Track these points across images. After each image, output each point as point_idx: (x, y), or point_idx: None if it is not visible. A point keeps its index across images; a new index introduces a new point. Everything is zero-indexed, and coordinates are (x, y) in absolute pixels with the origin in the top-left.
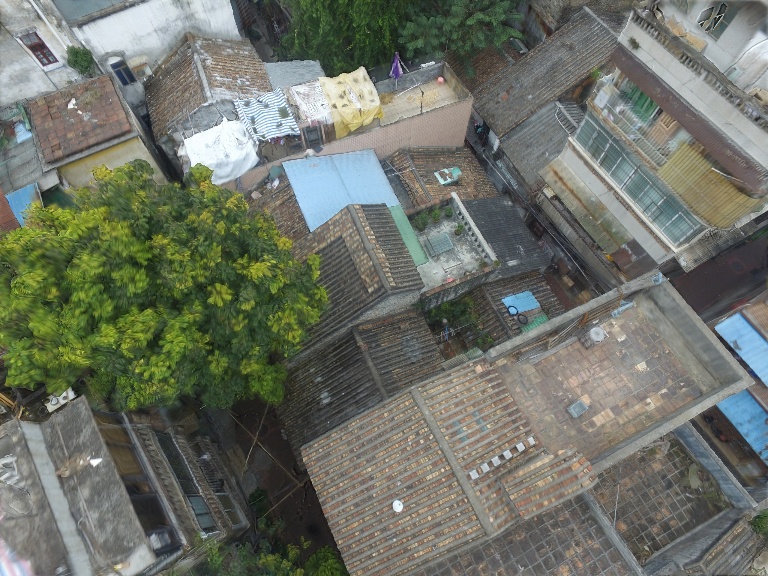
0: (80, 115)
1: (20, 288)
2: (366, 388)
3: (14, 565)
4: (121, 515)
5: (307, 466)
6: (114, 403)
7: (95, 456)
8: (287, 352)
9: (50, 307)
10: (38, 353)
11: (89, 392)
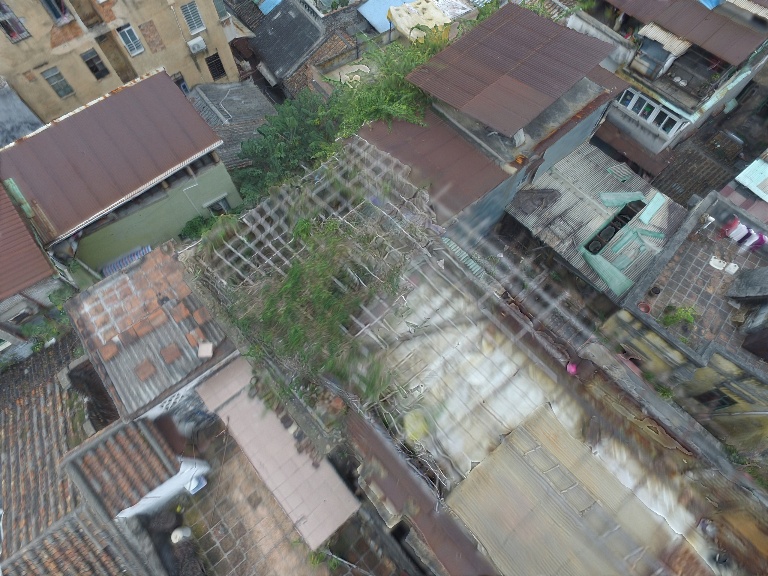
0: None
1: None
2: None
3: None
4: None
5: None
6: None
7: None
8: None
9: None
10: None
11: None
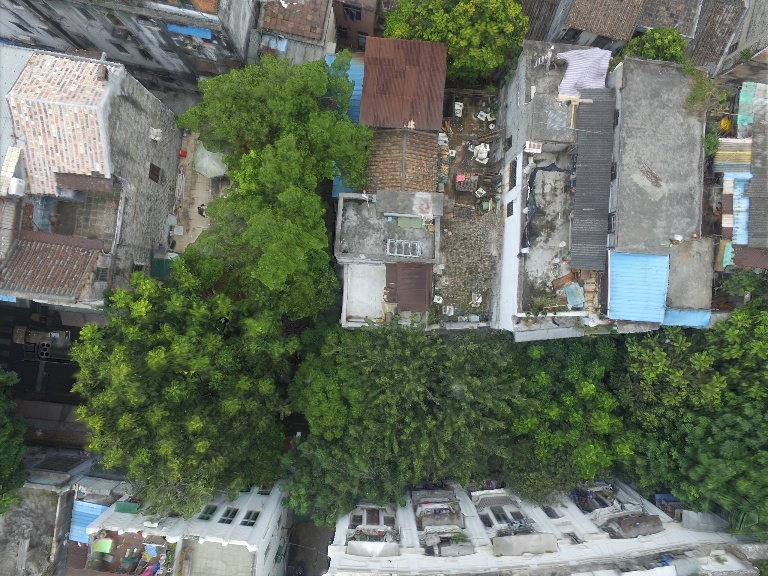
0: (297, 4)
1: (494, 6)
2: (537, 7)
3: (596, 48)
4: (577, 49)
5: (574, 26)
6: (514, 52)
7: (550, 47)
8: (522, 1)
9: (490, 18)
10: (499, 39)
11: (461, 100)
